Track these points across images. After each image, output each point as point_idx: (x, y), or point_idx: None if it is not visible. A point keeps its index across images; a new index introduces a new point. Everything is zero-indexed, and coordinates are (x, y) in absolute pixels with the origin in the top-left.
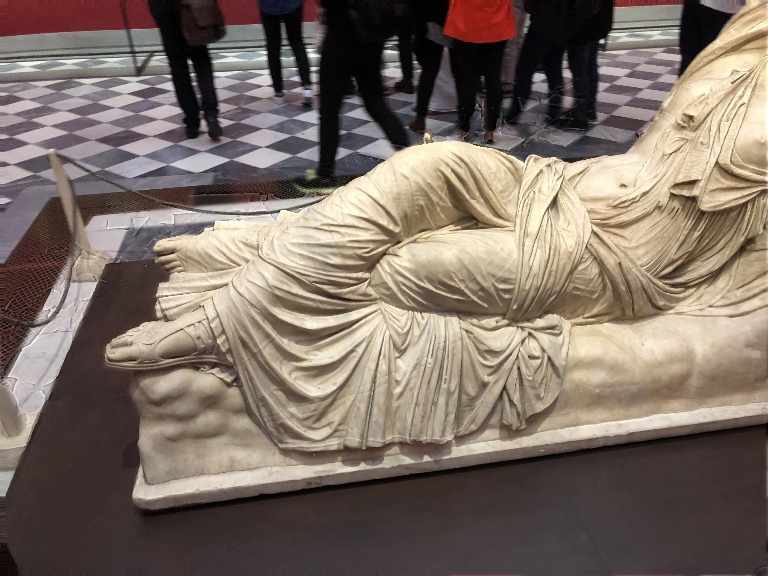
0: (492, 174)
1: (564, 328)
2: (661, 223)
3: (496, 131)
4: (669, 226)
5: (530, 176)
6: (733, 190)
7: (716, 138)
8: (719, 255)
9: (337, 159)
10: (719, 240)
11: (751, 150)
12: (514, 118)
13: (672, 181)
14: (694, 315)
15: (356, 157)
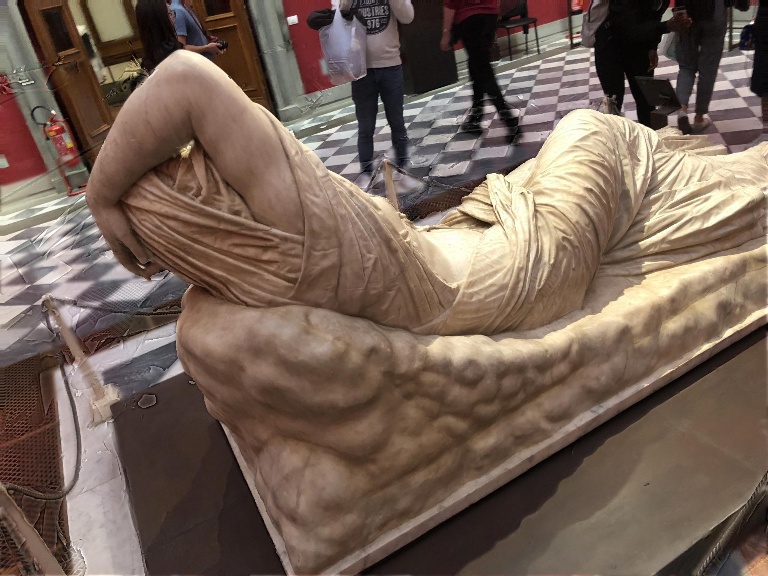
0: None
1: None
2: None
3: None
4: None
5: (517, 187)
6: None
7: None
8: None
9: None
10: None
11: None
12: None
13: None
14: None
15: None
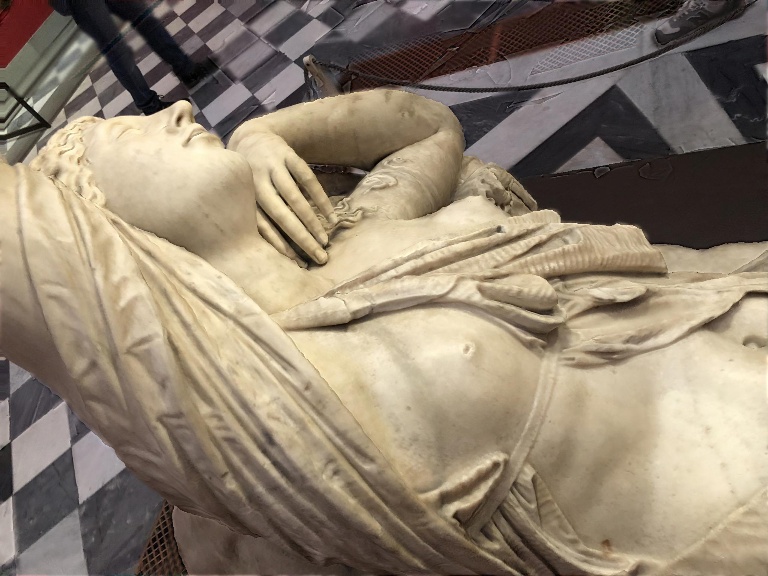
0: None
1: None
2: None
3: None
4: None
5: None
6: None
7: None
8: None
9: None
10: None
11: None
12: None
13: (659, 268)
14: None
15: None
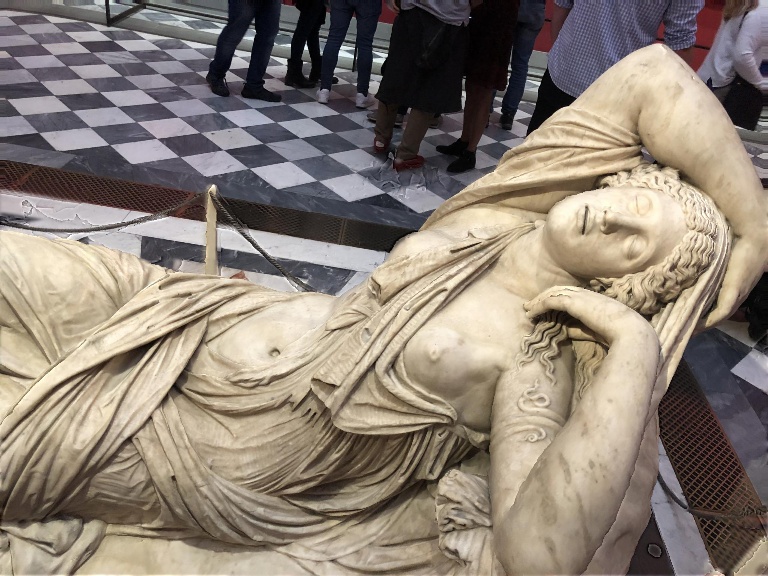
0: (55, 296)
1: (76, 544)
2: (289, 425)
3: (411, 187)
4: (300, 432)
5: (128, 308)
6: (391, 412)
7: (386, 330)
8: (377, 488)
9: (225, 174)
10: (381, 467)
11: (418, 365)
12: (461, 174)
13: None
14: (304, 567)
15: (247, 176)
